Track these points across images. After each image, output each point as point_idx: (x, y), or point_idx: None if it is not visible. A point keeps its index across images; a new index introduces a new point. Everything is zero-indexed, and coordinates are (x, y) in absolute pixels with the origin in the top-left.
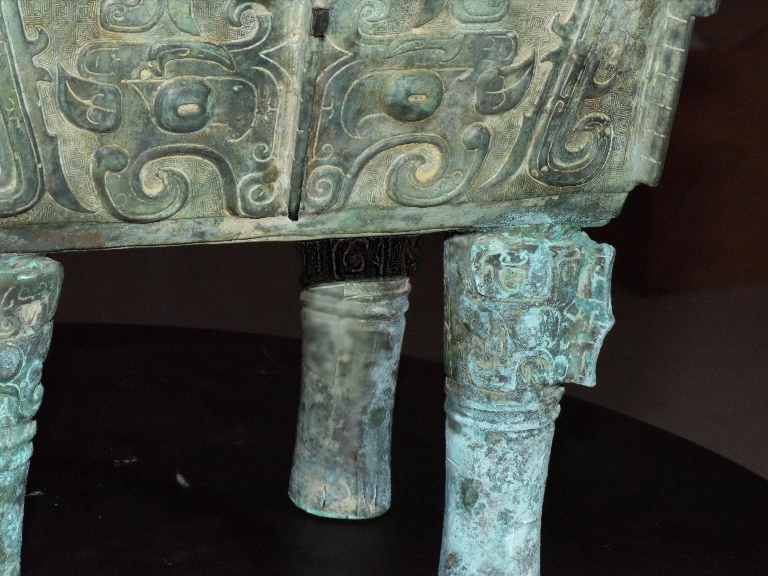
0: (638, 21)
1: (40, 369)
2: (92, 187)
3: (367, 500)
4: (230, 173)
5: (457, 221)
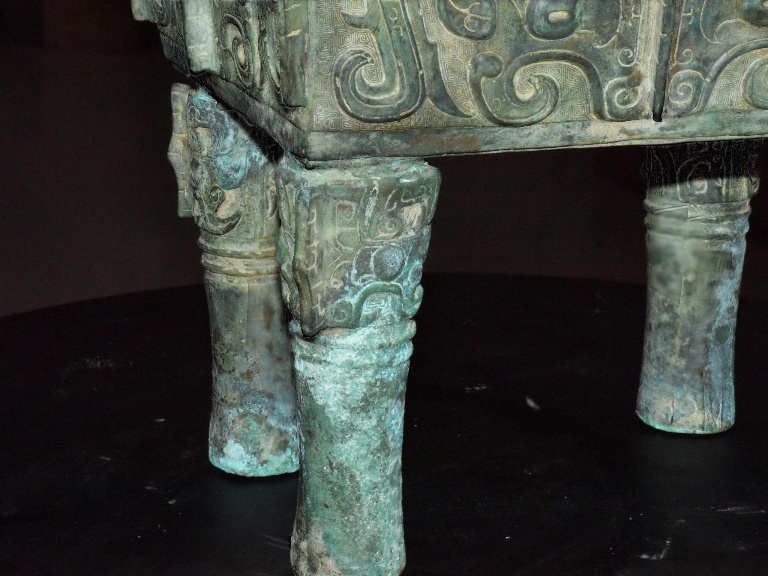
0: None
1: (420, 269)
2: (469, 92)
3: (713, 415)
4: (597, 78)
5: None
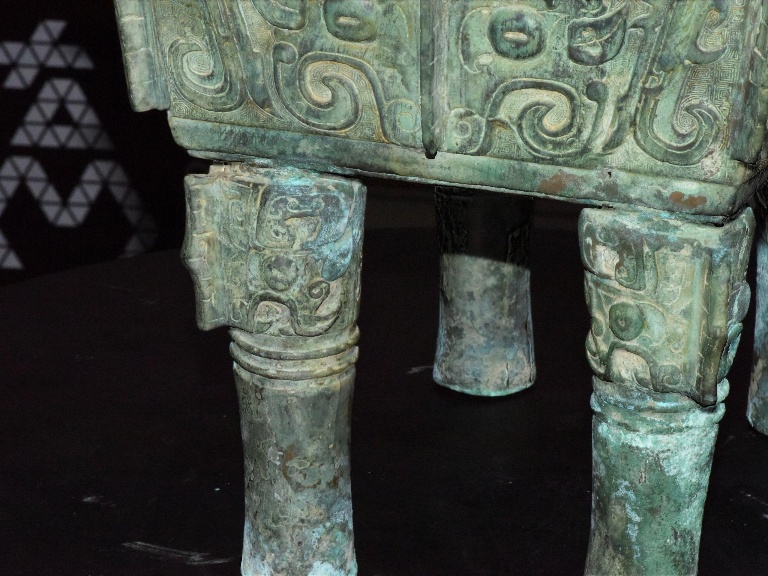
0: None
1: None
2: None
3: (533, 364)
4: None
5: None
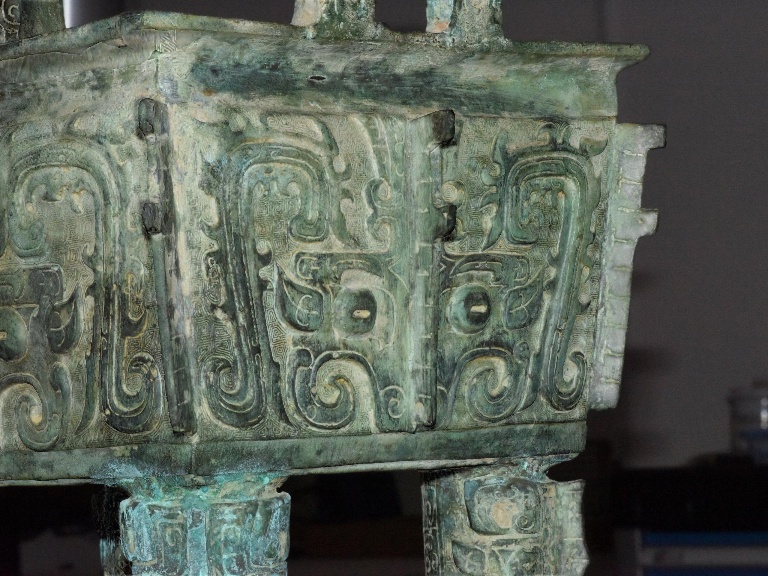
0: (148, 249)
1: None
2: None
3: None
4: None
5: (77, 470)
